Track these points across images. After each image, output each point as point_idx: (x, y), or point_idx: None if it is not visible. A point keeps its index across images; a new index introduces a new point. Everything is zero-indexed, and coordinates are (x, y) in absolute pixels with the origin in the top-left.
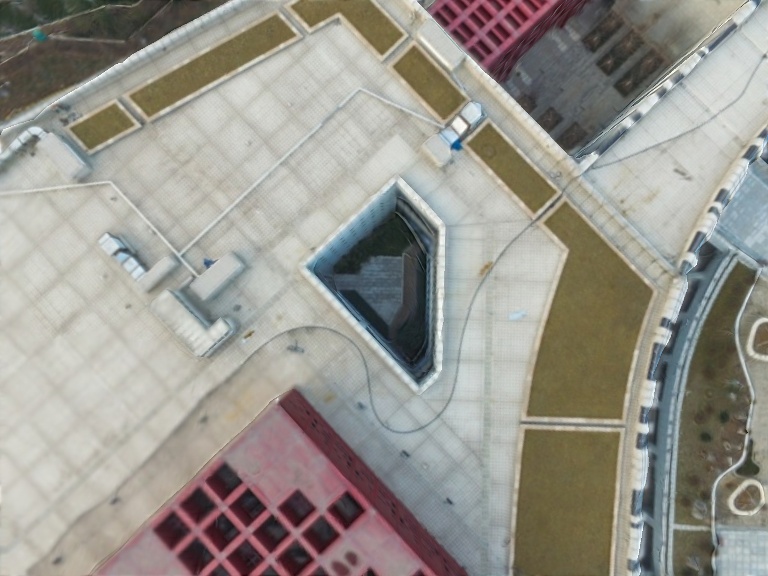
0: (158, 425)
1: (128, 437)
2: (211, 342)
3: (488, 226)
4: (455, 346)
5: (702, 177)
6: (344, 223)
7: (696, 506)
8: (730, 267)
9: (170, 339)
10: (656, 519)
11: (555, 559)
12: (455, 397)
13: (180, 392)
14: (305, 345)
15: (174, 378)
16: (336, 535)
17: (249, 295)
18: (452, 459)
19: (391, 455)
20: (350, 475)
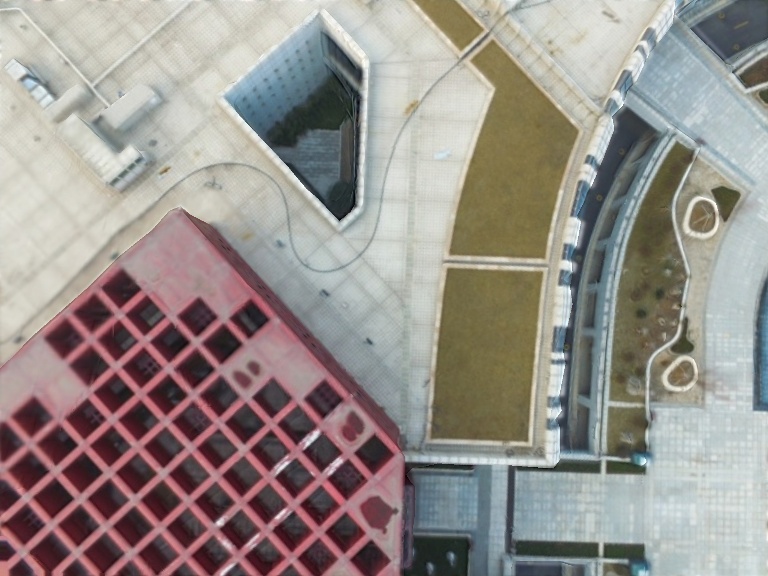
0: (67, 262)
1: (35, 274)
2: (120, 168)
3: (414, 64)
4: (378, 185)
5: (630, 20)
6: (264, 53)
7: (630, 382)
8: (669, 147)
9: (79, 169)
10: (592, 398)
11: (475, 398)
12: (377, 237)
13: (91, 229)
14: (223, 182)
15: (85, 214)
16: (238, 343)
17: (166, 131)
18: (373, 299)
19: (310, 294)
20: (257, 290)
